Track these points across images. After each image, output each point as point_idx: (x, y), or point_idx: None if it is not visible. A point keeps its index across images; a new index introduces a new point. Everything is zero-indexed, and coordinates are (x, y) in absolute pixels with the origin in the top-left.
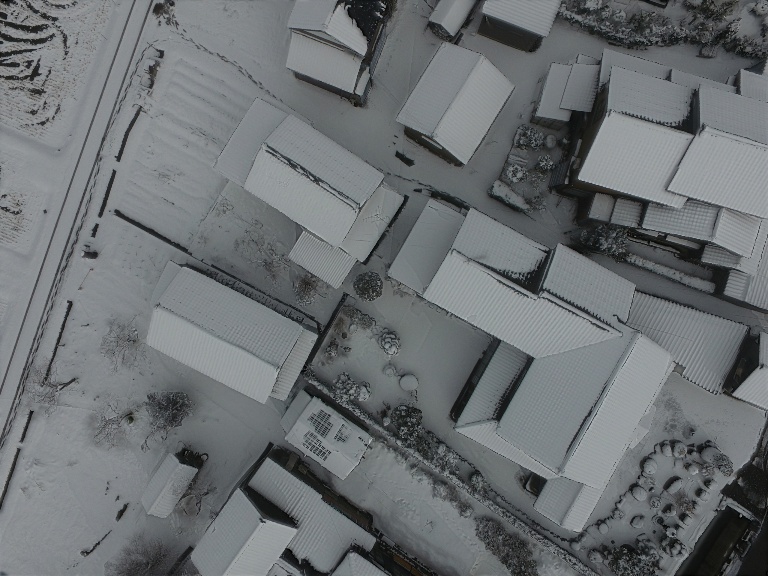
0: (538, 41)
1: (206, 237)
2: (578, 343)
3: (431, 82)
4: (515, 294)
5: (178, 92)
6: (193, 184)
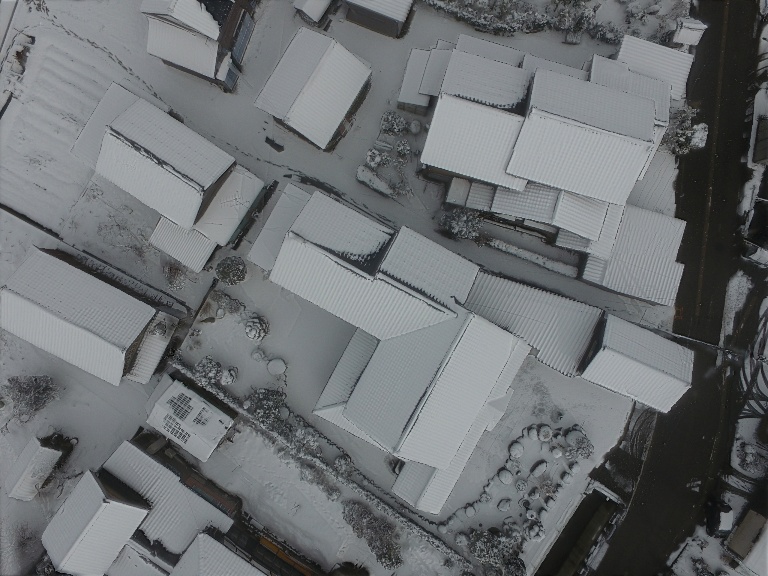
0: (406, 27)
1: (76, 222)
2: (418, 324)
3: (287, 67)
4: (353, 276)
5: (49, 78)
6: (64, 170)
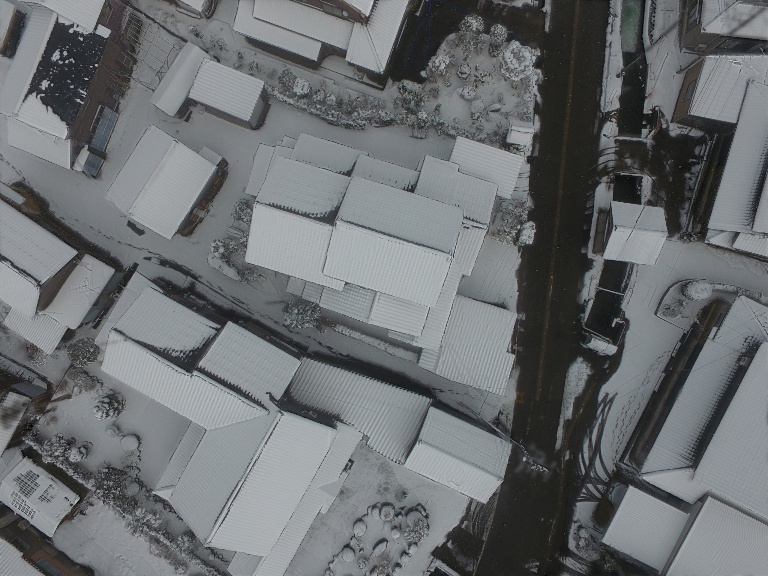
0: (262, 120)
1: None
2: (236, 418)
3: (135, 163)
4: (174, 371)
5: None
6: None
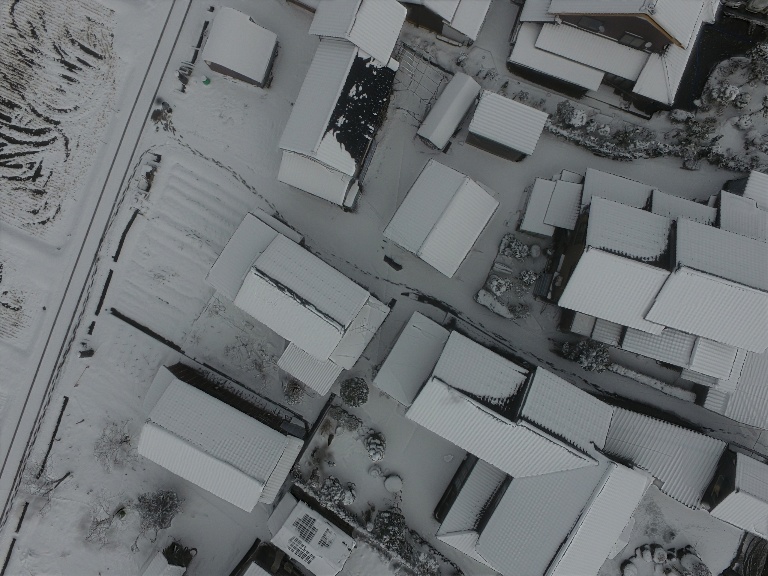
0: None
1: (199, 337)
2: (556, 468)
3: (417, 199)
4: (494, 420)
5: (174, 195)
6: (187, 284)
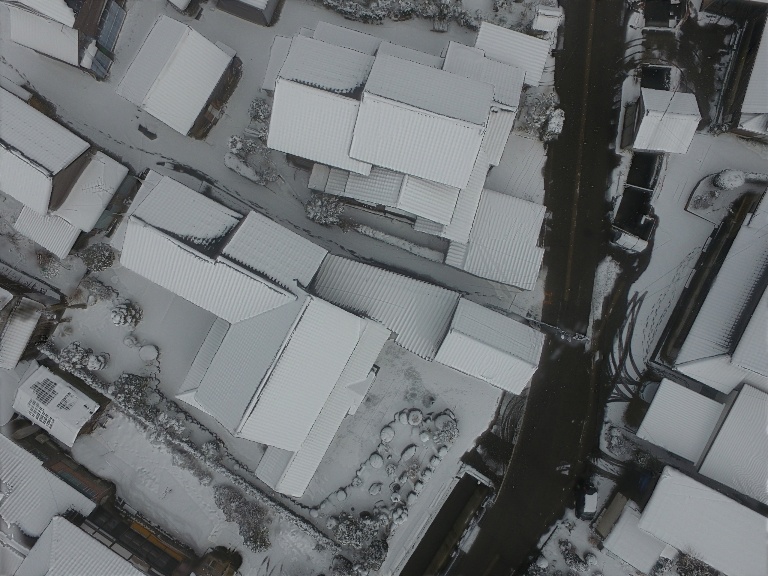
0: (276, 16)
1: None
2: (263, 307)
3: (146, 54)
4: (196, 259)
5: None
6: None
